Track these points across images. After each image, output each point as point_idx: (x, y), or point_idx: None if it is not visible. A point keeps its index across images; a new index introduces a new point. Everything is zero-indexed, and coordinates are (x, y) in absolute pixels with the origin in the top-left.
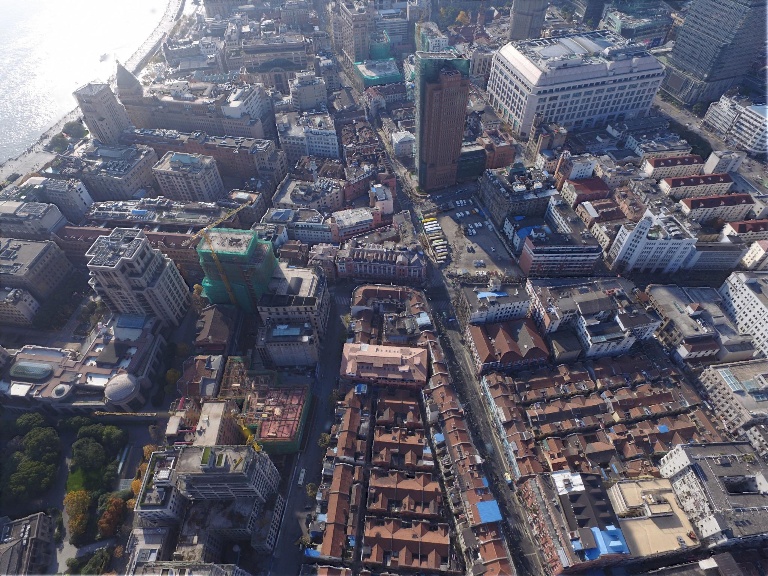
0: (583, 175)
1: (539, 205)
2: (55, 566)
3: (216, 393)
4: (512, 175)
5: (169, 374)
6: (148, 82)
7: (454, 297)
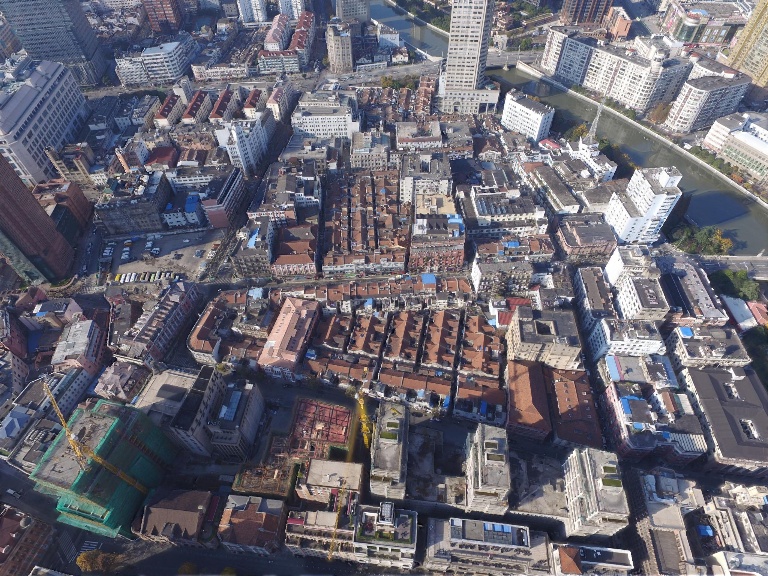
0: (145, 155)
1: (163, 190)
2: None
3: None
4: (116, 192)
5: None
6: None
7: (228, 280)
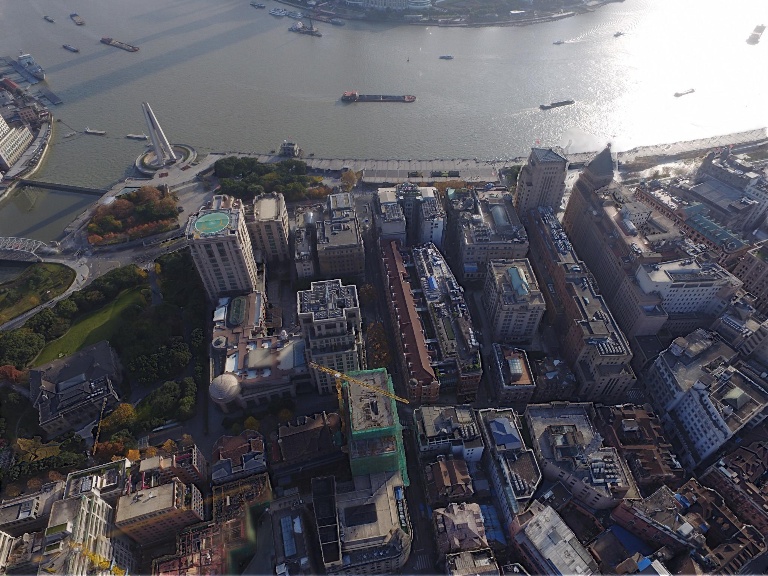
0: None
1: None
2: (82, 427)
3: (223, 481)
4: None
5: (248, 420)
6: (666, 175)
7: None
